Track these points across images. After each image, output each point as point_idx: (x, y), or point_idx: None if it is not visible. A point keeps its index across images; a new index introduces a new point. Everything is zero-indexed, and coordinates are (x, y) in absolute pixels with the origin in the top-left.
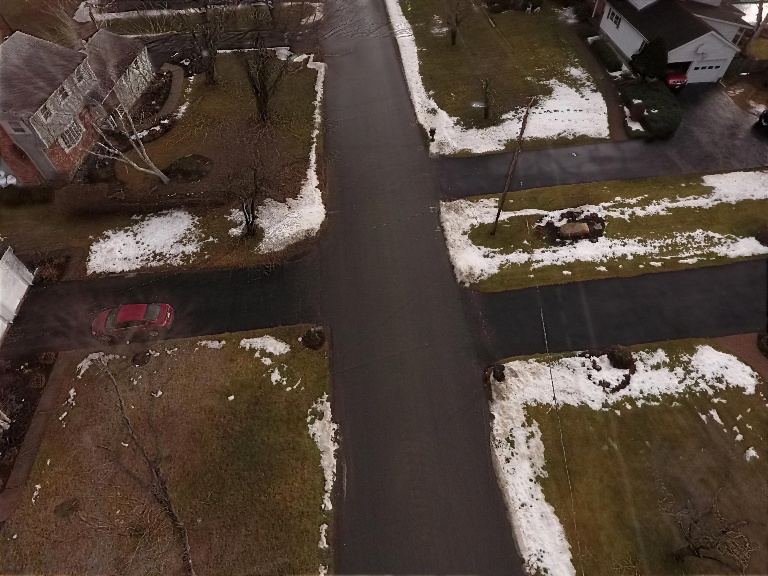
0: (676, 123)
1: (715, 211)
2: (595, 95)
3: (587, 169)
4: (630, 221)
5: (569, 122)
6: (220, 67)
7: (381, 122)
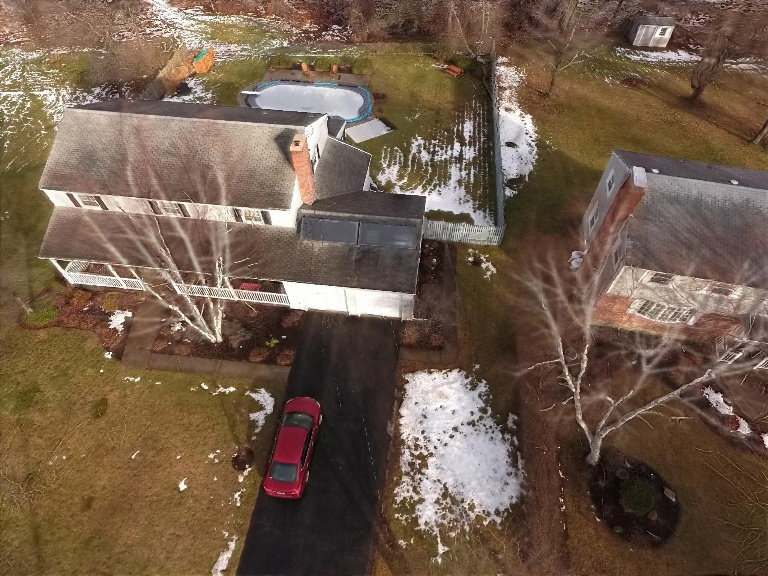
0: None
1: None
2: None
3: None
4: None
5: None
6: None
7: None
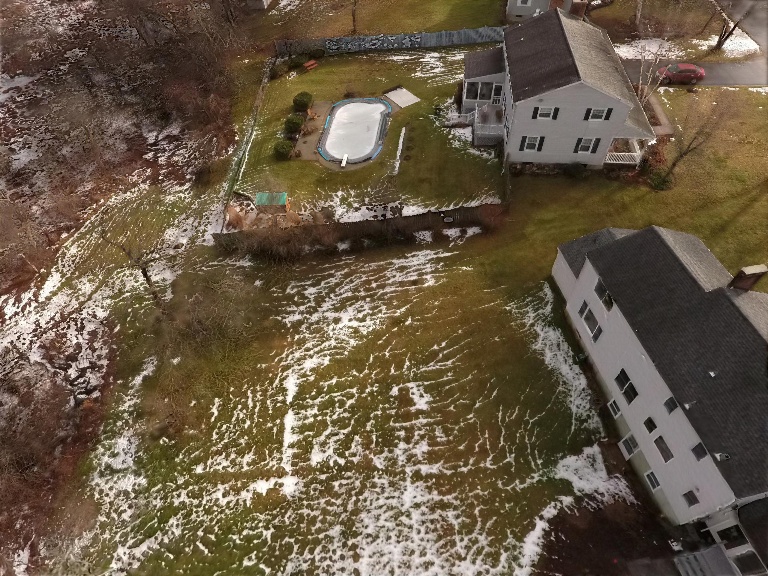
0: None
1: None
2: None
3: None
4: None
5: None
6: None
7: None
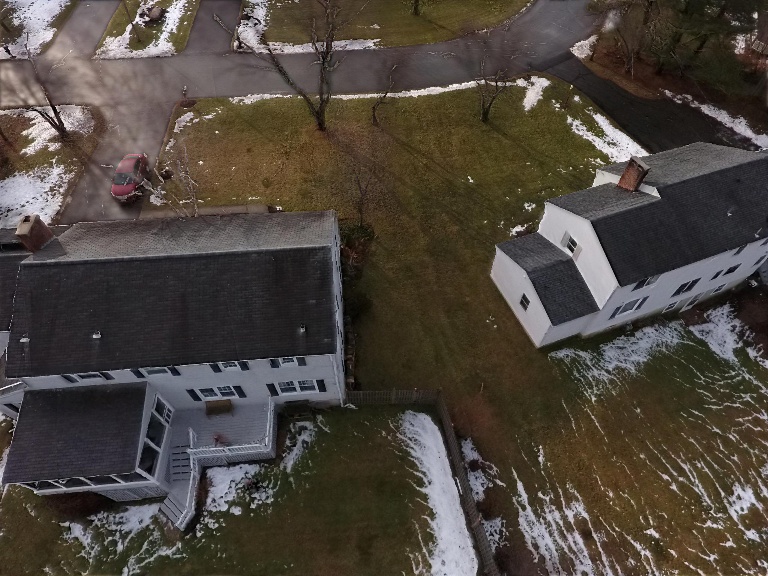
0: None
1: None
2: None
3: (106, 4)
4: None
5: (51, 1)
6: None
7: None
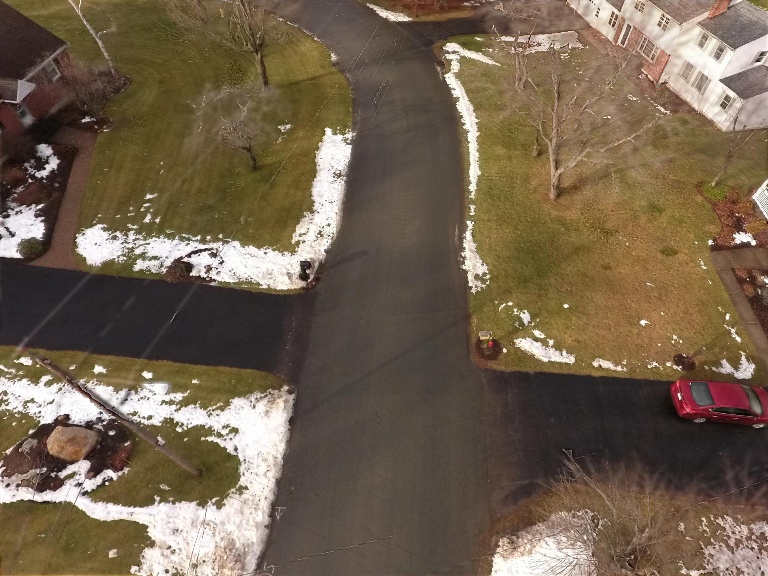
0: None
1: None
2: None
3: None
4: None
5: None
6: None
7: None
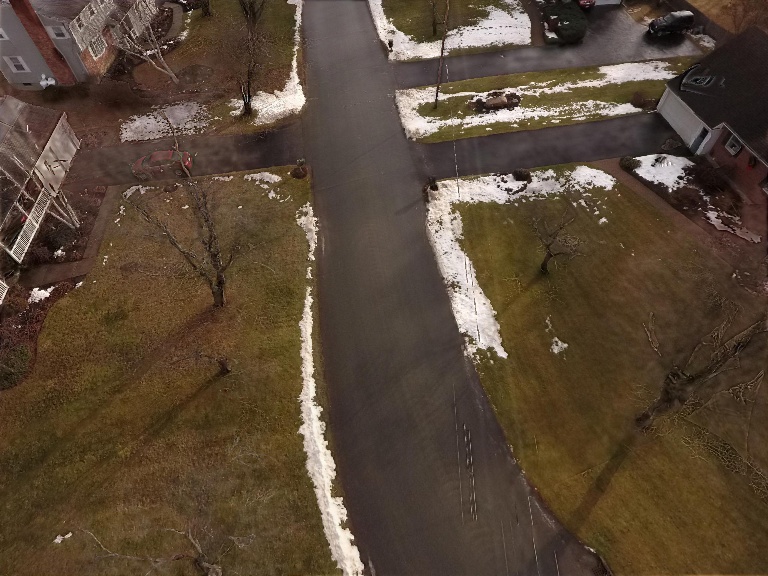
0: (582, 31)
1: (604, 89)
2: (523, 15)
3: (511, 66)
4: (540, 97)
5: (500, 35)
6: (213, 4)
7: (350, 40)
